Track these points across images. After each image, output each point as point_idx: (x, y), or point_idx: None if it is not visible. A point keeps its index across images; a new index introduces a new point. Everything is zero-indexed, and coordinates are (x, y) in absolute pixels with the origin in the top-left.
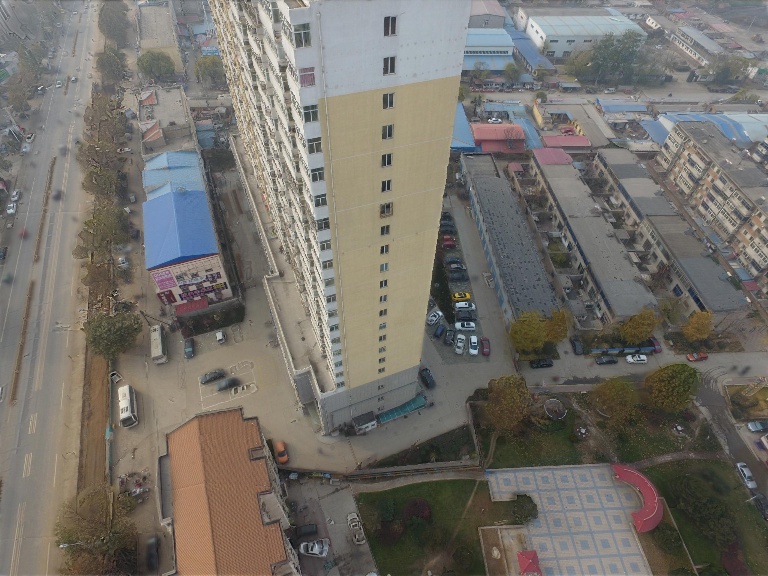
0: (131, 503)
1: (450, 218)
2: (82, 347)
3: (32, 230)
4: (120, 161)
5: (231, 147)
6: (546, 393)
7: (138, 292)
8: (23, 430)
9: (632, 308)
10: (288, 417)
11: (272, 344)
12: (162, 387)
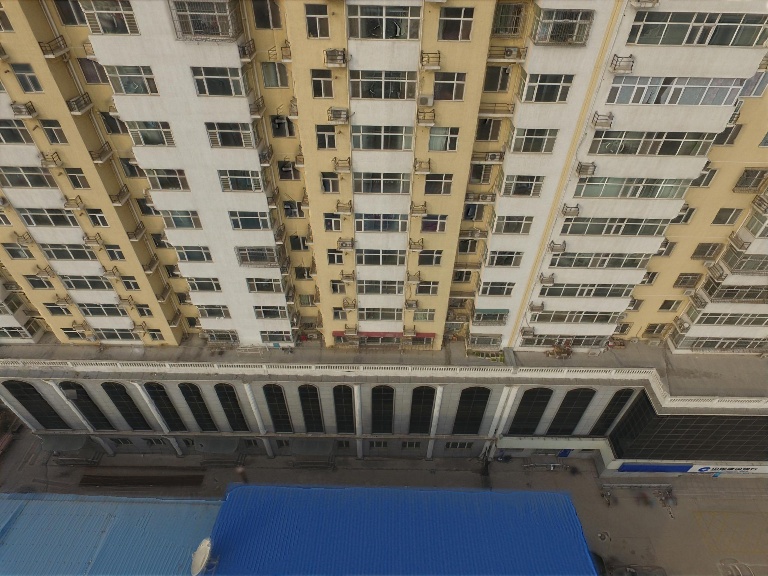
0: None
1: None
2: None
3: None
4: None
5: (32, 377)
6: None
7: None
8: None
9: None
10: None
11: (669, 503)
12: None
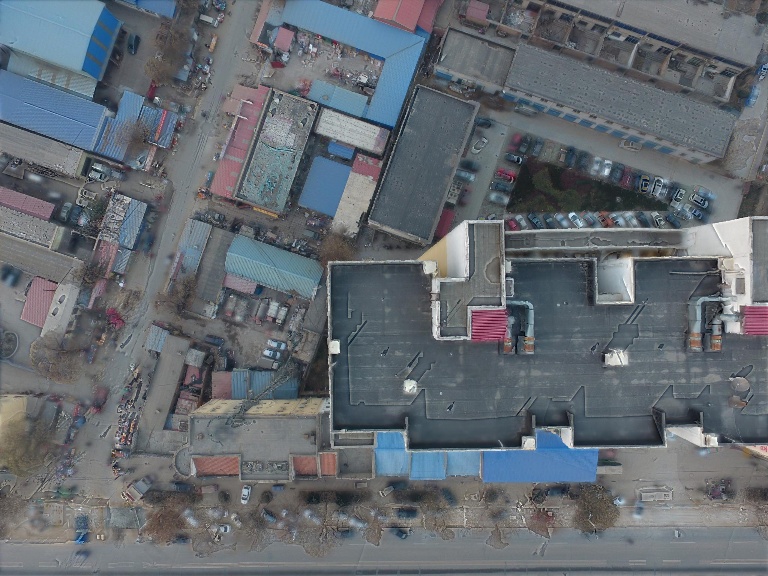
0: (729, 492)
1: (531, 138)
2: (572, 530)
3: None
4: (271, 500)
5: None
6: (761, 167)
7: (522, 483)
8: (641, 569)
9: (753, 47)
10: None
11: None
12: (640, 466)
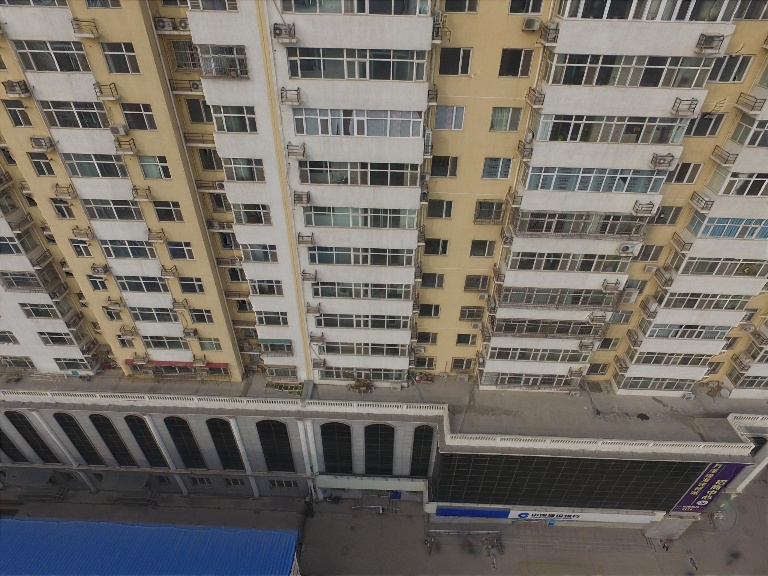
0: None
1: None
2: None
3: None
4: None
5: None
6: None
7: None
8: None
9: None
10: (685, 572)
11: (494, 552)
12: None
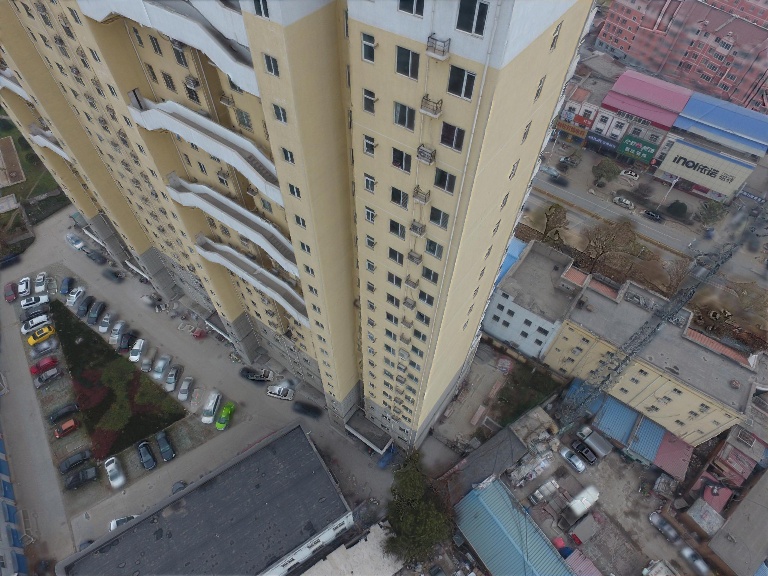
0: None
1: None
2: None
3: (569, 198)
4: None
5: None
6: None
7: None
8: None
9: None
10: None
11: None
12: None
